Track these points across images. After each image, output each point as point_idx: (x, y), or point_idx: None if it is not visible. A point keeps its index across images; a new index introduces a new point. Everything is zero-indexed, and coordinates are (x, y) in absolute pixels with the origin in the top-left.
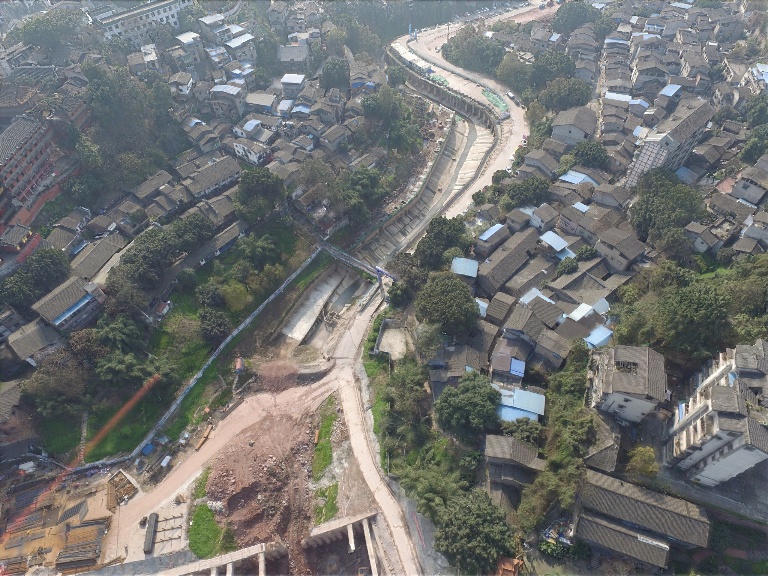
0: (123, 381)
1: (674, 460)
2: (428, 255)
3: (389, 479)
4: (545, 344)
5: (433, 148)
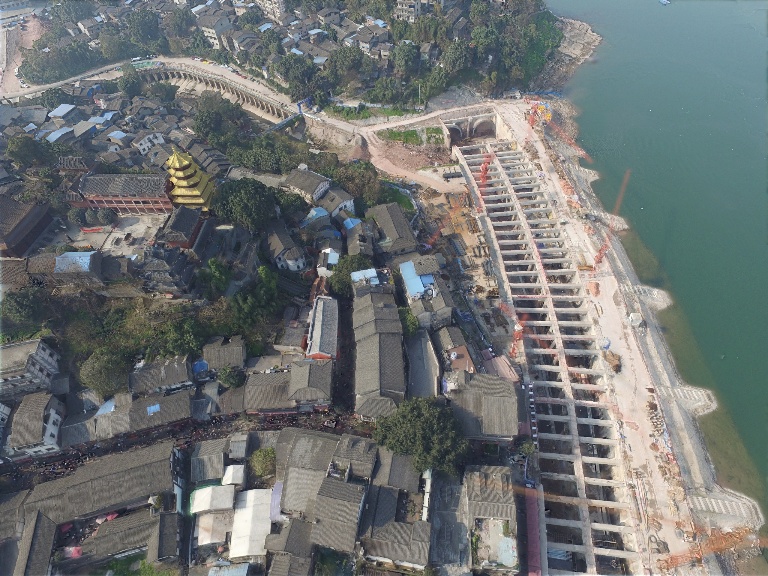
0: None
1: None
2: (307, 70)
3: (426, 110)
4: (381, 33)
5: (175, 95)
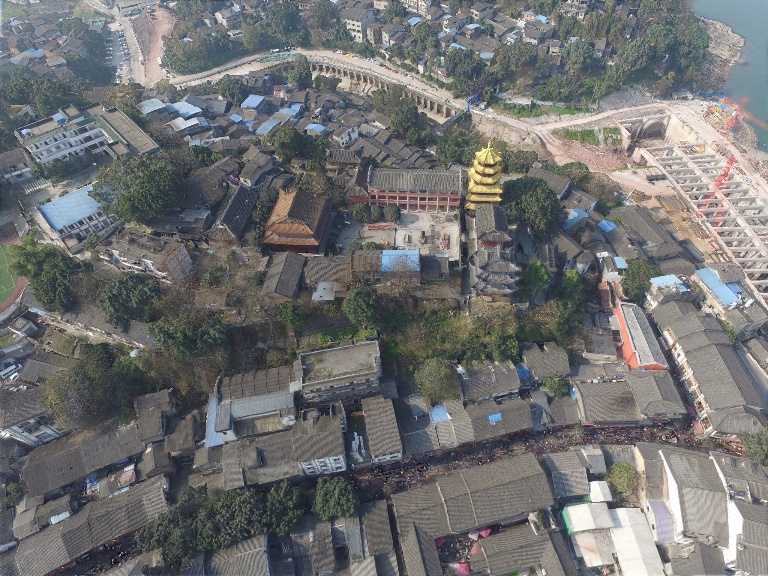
0: None
1: (603, 4)
2: (477, 65)
3: (598, 110)
4: (548, 29)
5: None
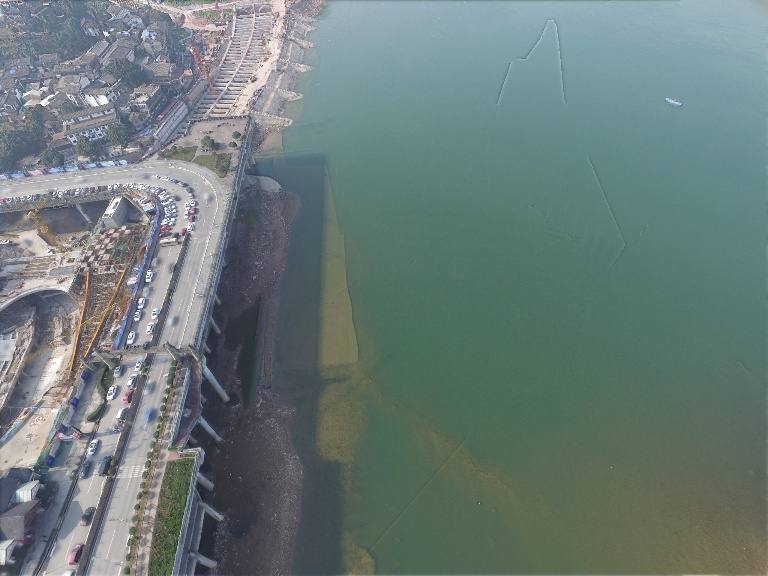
0: (164, 16)
1: None
2: None
3: (226, 1)
4: None
5: None
